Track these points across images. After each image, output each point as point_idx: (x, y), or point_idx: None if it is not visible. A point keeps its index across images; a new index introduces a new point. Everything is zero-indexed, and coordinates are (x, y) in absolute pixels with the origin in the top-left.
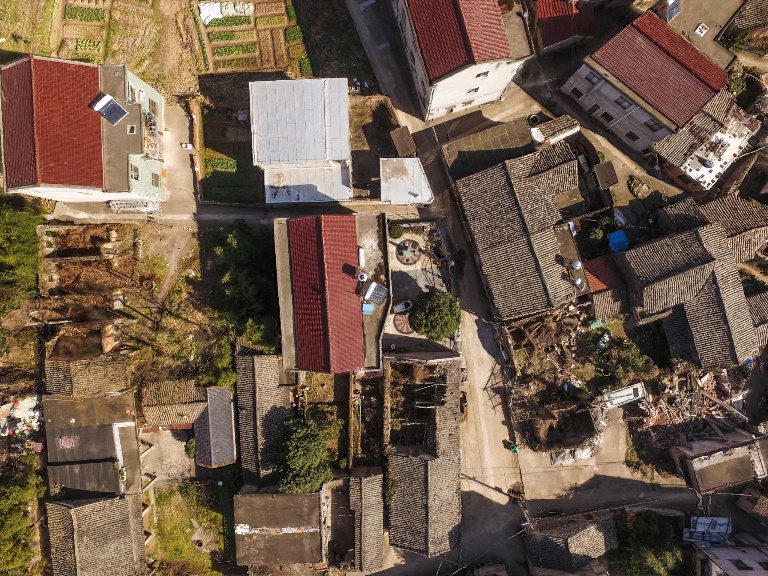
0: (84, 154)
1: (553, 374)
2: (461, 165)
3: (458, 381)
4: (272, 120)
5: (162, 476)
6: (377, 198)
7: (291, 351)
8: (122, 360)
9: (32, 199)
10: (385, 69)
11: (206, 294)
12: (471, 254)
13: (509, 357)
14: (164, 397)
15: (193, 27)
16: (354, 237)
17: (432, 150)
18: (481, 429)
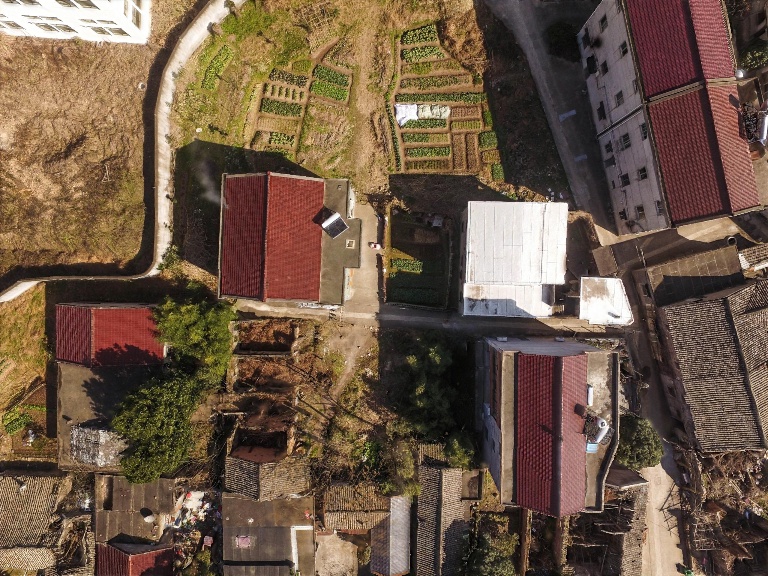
0: (305, 268)
1: (735, 501)
2: (666, 290)
3: (644, 506)
4: (489, 241)
5: (324, 575)
6: (575, 316)
7: (509, 485)
8: (304, 462)
9: (214, 288)
10: (580, 181)
11: (382, 394)
12: (657, 372)
13: (692, 481)
14: (345, 503)
15: (388, 127)
16: (585, 376)
17: (623, 265)
18: (655, 551)
